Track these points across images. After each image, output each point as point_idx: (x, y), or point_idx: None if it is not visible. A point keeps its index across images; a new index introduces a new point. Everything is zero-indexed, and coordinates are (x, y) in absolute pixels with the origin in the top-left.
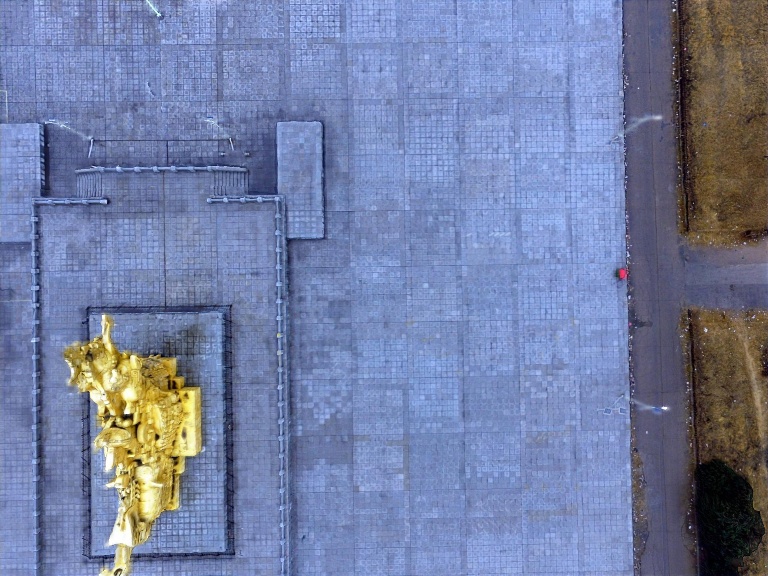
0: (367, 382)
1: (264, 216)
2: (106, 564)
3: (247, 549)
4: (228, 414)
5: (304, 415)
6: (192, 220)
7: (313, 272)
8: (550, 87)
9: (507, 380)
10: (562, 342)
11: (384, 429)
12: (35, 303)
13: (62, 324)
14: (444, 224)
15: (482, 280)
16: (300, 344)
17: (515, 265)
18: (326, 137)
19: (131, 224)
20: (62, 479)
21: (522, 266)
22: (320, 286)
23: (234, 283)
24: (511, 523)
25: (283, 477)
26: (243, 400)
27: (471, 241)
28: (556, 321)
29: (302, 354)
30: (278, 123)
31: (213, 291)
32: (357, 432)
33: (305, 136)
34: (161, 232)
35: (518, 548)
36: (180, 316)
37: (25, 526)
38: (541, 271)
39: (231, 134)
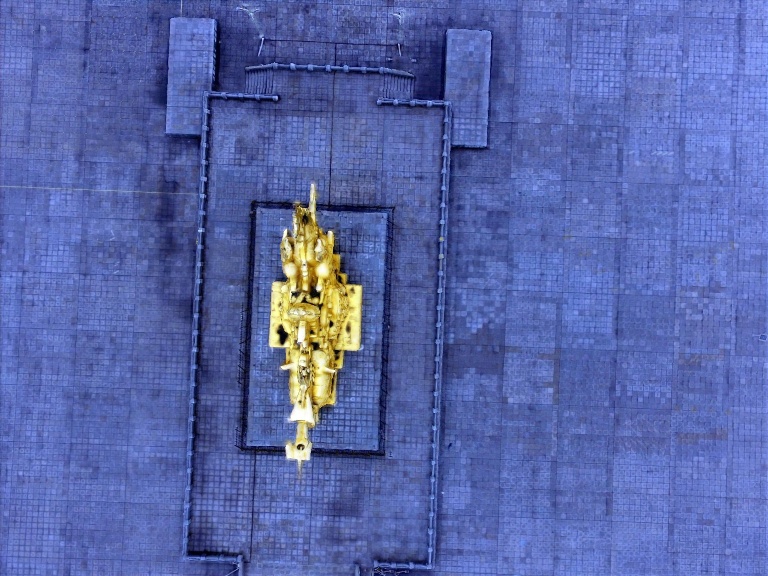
0: (521, 294)
1: (431, 121)
2: (258, 456)
3: (397, 451)
4: (386, 315)
5: (457, 323)
6: (360, 121)
7: (473, 181)
8: (721, 8)
9: (662, 300)
10: (720, 265)
11: (536, 342)
12: (204, 193)
13: (227, 217)
14: (607, 140)
15: (642, 198)
16: (456, 252)
17: (676, 185)
18: (493, 48)
19: (299, 122)
20: (219, 370)
21: (683, 186)
22: (479, 196)
23: (398, 186)
24: (659, 444)
25: (437, 381)
26: (401, 302)
27: (633, 159)
28: (715, 244)
29: (458, 262)
30: (449, 30)
31: (377, 193)
32: (509, 343)
33: (475, 44)
34: (328, 131)
35: (665, 470)
36: (346, 214)
37: (177, 416)
38: (702, 193)
39: (399, 40)
